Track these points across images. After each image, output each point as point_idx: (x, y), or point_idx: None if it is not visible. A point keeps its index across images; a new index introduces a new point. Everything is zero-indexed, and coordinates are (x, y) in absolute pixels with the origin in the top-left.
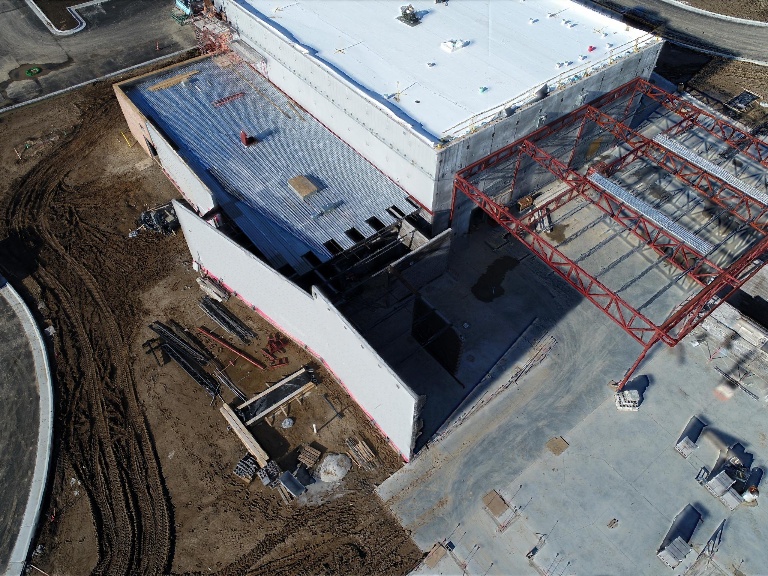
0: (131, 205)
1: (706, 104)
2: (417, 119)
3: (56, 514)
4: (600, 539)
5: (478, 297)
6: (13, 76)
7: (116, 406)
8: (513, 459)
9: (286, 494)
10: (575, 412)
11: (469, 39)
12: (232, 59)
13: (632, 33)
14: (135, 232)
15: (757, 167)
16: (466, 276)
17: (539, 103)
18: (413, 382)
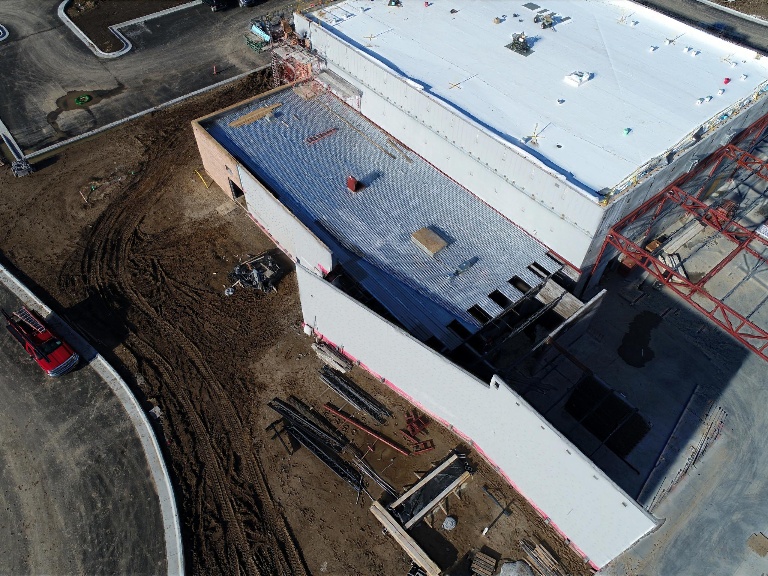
0: (220, 256)
1: None
2: (565, 167)
3: None
4: None
5: (628, 361)
6: (61, 105)
7: (248, 506)
8: (715, 563)
9: None
10: None
11: (592, 71)
12: (316, 90)
13: (764, 62)
14: (231, 289)
15: None
16: (608, 336)
17: (695, 147)
18: None
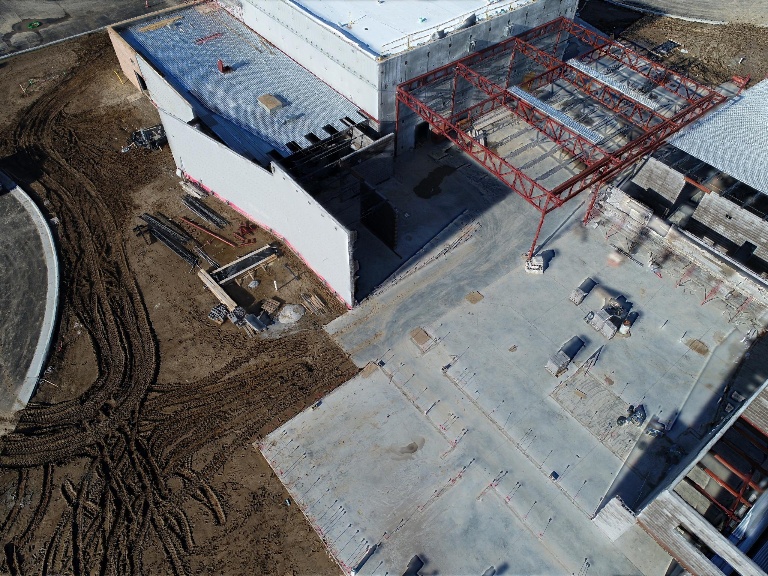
0: (123, 128)
1: None
2: (365, 41)
3: (63, 346)
4: (501, 359)
5: (419, 195)
6: (16, 29)
7: (111, 273)
8: (437, 307)
9: (251, 331)
10: (491, 275)
11: None
12: (212, 7)
13: None
14: (127, 148)
15: None
16: (410, 180)
17: (468, 29)
18: (359, 255)
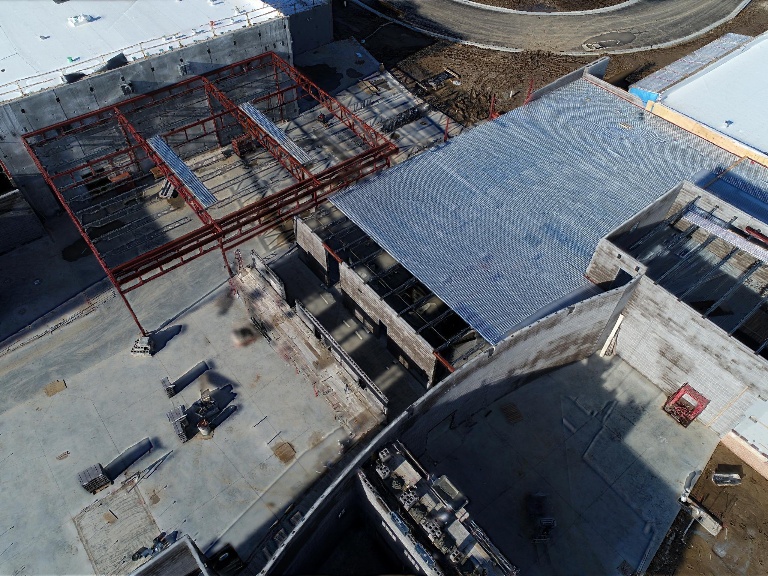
0: None
1: (401, 83)
2: None
3: None
4: (42, 469)
5: (64, 257)
6: None
7: None
8: (5, 400)
9: None
10: (91, 358)
11: (102, 15)
12: None
13: (265, 10)
14: None
15: (411, 139)
16: (65, 238)
17: (114, 71)
18: None
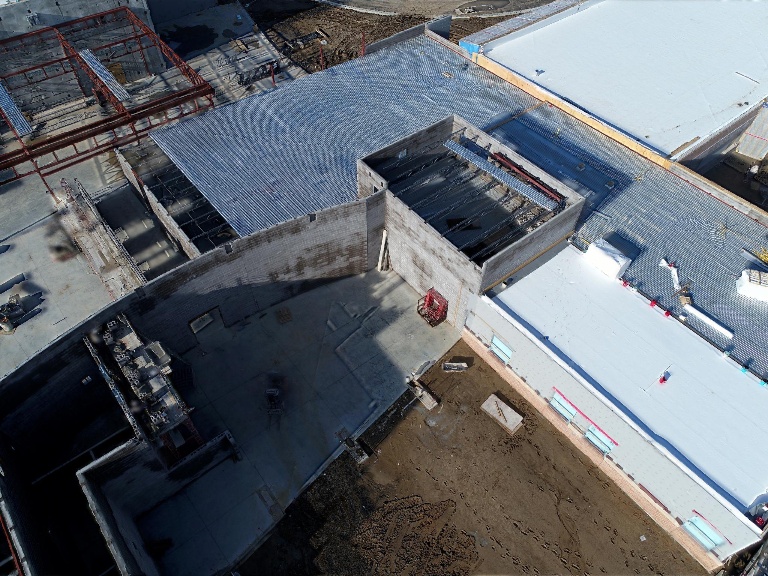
0: None
1: (272, 42)
2: None
3: None
4: None
5: None
6: None
7: None
8: None
9: None
10: None
11: None
12: None
13: None
14: None
15: None
16: None
17: None
18: None
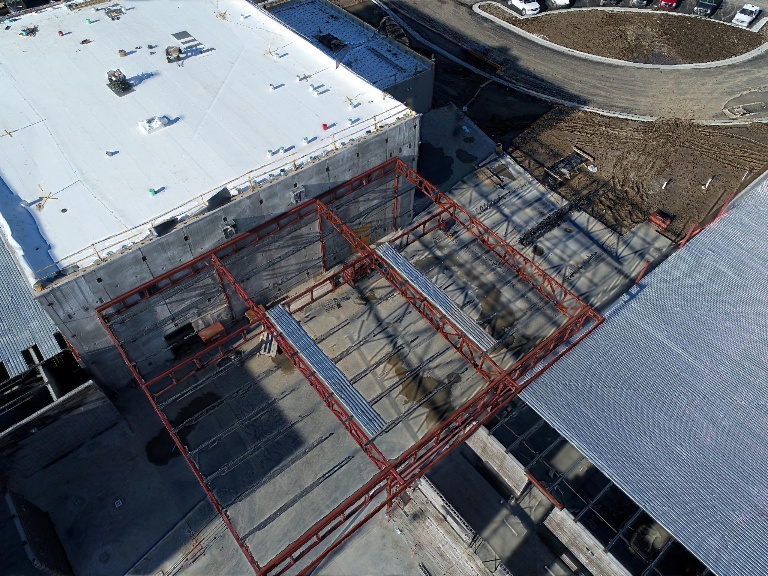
0: None
1: (526, 169)
2: (49, 238)
3: None
4: None
5: (150, 458)
6: None
7: None
8: None
9: None
10: None
11: (181, 114)
12: None
13: (387, 103)
14: None
15: (560, 255)
16: (147, 425)
17: (216, 212)
18: None
